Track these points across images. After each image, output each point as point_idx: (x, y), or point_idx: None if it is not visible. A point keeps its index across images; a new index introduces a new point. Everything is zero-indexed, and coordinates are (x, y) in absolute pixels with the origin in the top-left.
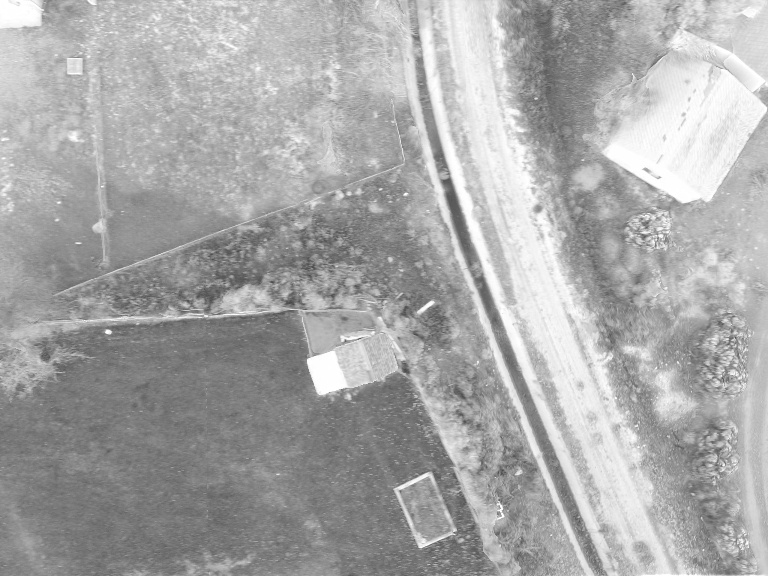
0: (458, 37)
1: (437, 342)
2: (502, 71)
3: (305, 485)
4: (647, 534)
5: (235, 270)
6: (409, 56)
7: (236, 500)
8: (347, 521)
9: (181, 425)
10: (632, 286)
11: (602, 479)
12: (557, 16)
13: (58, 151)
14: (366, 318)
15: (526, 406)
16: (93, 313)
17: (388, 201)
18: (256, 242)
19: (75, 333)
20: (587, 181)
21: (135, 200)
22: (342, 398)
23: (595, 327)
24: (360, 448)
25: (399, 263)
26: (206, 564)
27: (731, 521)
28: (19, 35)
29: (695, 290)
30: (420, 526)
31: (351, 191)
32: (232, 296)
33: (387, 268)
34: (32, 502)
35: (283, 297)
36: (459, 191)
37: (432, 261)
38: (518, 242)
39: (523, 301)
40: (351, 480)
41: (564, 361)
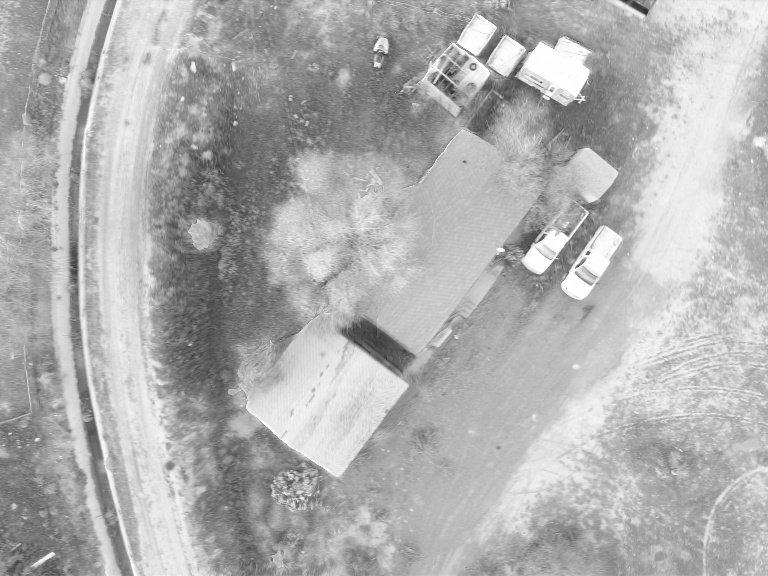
0: (108, 280)
1: None
2: (148, 320)
3: None
4: None
5: None
6: (61, 293)
7: None
8: None
9: None
10: (273, 544)
11: None
12: (223, 259)
13: None
14: None
15: None
16: None
17: (17, 446)
18: None
19: None
20: (242, 429)
21: None
22: None
23: None
24: None
25: (24, 510)
26: None
27: None
28: None
29: (344, 549)
30: None
31: None
32: None
33: (8, 516)
34: None
35: None
36: (100, 435)
37: (58, 510)
38: (149, 497)
39: (148, 558)
40: None
41: None
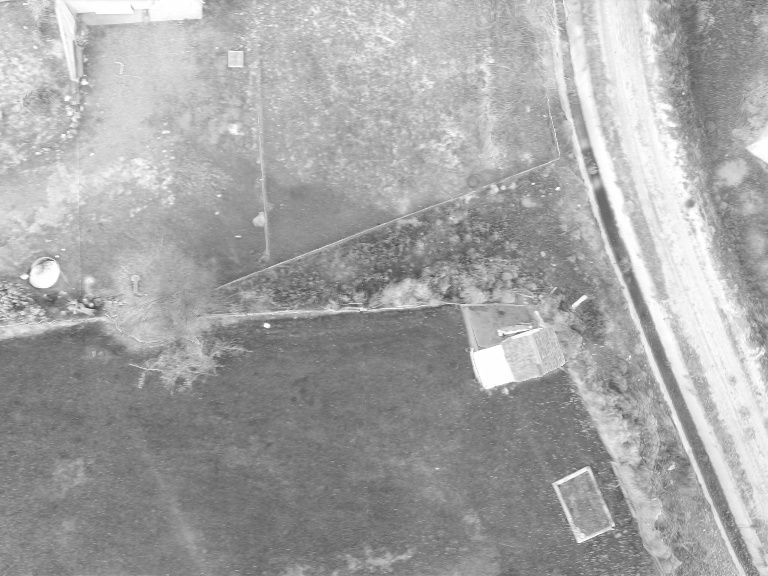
0: (608, 32)
1: (591, 337)
2: (653, 66)
3: (464, 479)
4: None
5: (393, 264)
6: (558, 51)
7: (396, 494)
8: (506, 516)
9: (340, 419)
10: None
11: (755, 474)
12: (703, 11)
13: (218, 144)
14: (523, 312)
15: (675, 401)
16: (253, 306)
17: (541, 195)
18: (414, 236)
19: (234, 327)
20: (731, 176)
21: (294, 193)
22: (499, 392)
23: (746, 322)
24: (518, 442)
25: (551, 257)
26: (367, 558)
27: None
28: (180, 28)
29: None
30: (578, 521)
31: (505, 185)
32: (394, 290)
33: (541, 262)
34: (193, 496)
35: (442, 291)
36: (608, 186)
37: (584, 256)
38: (670, 237)
39: (675, 296)
40: (509, 475)
41: (716, 356)
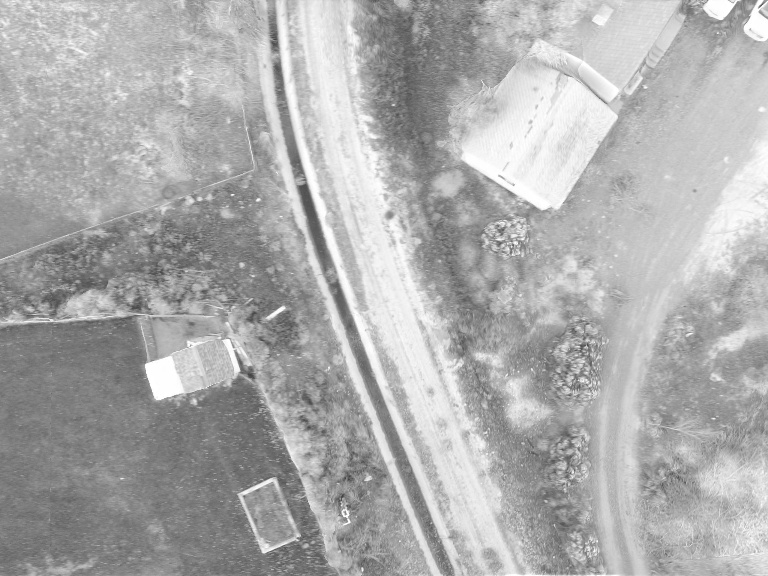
0: (313, 43)
1: (286, 348)
2: (356, 77)
3: (149, 490)
4: (496, 541)
5: (82, 275)
6: (266, 62)
7: (79, 504)
8: (190, 526)
9: (25, 429)
10: (488, 293)
11: (451, 485)
12: (417, 23)
13: None
14: (213, 323)
15: (380, 412)
16: None
17: (240, 207)
18: (103, 247)
19: None
20: (447, 187)
21: None
22: (188, 403)
23: (447, 334)
24: (205, 453)
25: (251, 269)
26: (47, 568)
27: (581, 528)
28: None
29: (554, 297)
30: (264, 531)
31: (202, 196)
32: (75, 301)
33: (237, 273)
34: None
35: (128, 302)
36: (314, 197)
37: (284, 267)
38: (370, 248)
39: (375, 307)
40: (195, 485)
41: (415, 367)
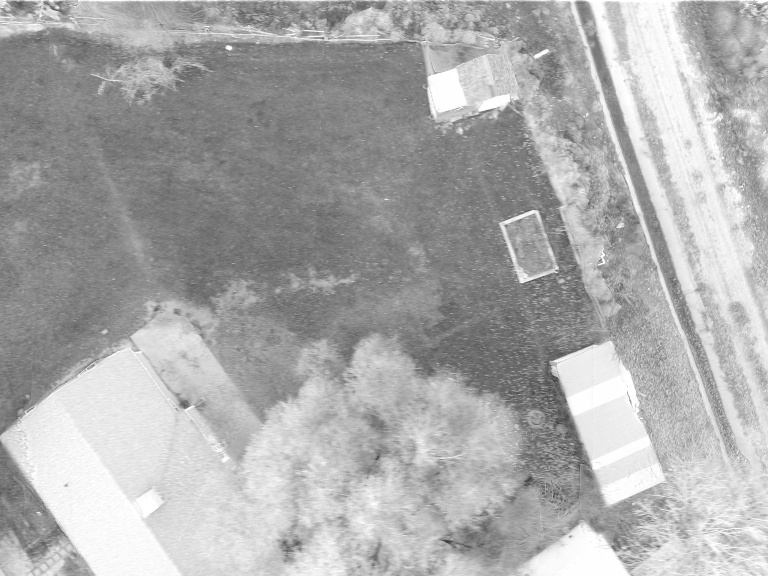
0: None
1: (550, 88)
2: None
3: (412, 212)
4: (744, 295)
5: None
6: None
7: (344, 220)
8: (451, 251)
9: (294, 143)
10: (743, 58)
11: (703, 238)
12: None
13: None
14: None
15: (630, 166)
16: (216, 26)
17: None
18: None
19: (196, 46)
20: None
21: None
22: (454, 131)
23: (706, 88)
24: (468, 181)
25: (516, 10)
26: (311, 279)
27: None
28: None
29: None
30: (523, 262)
31: None
32: (355, 16)
33: (505, 12)
34: (144, 205)
35: (404, 25)
36: None
37: (549, 11)
38: None
39: (637, 57)
40: (458, 211)
41: (673, 119)
